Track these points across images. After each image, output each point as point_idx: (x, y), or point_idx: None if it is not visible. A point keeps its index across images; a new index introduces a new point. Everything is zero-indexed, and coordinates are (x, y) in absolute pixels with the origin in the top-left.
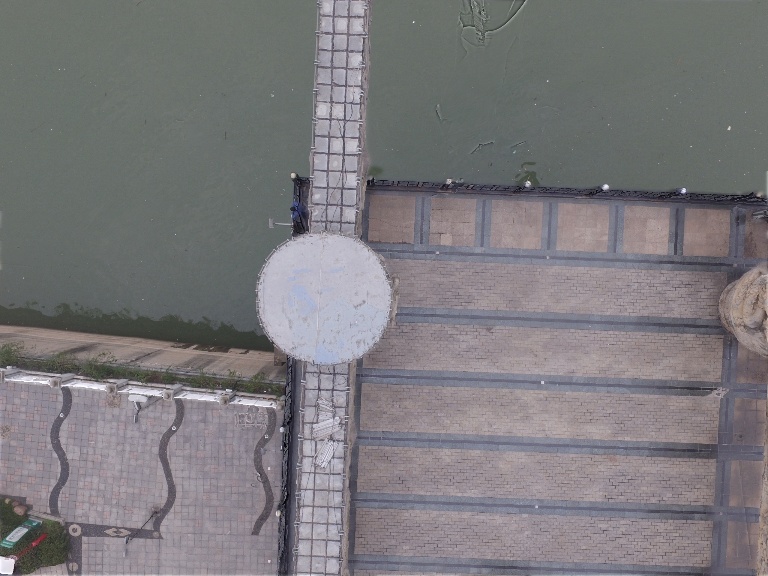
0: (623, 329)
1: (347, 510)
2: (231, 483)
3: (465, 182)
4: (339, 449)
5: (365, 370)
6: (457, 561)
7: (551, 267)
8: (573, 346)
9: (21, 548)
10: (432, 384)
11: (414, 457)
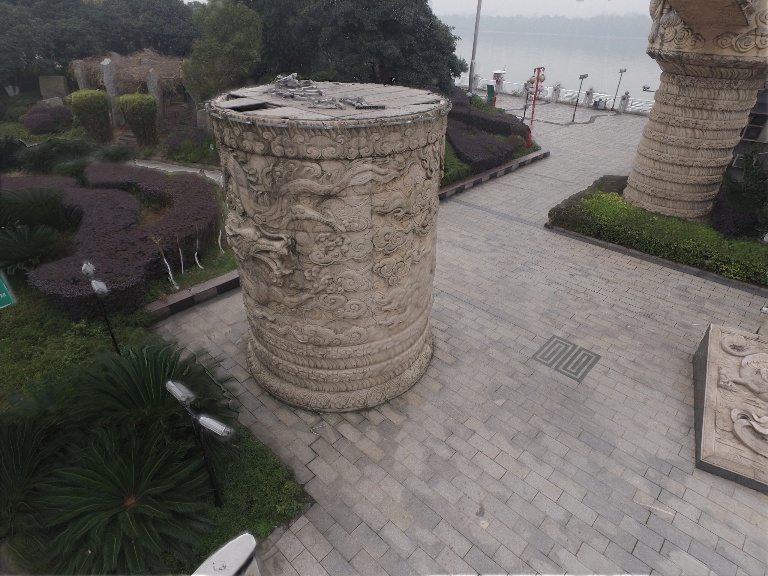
0: None
1: None
2: (640, 128)
3: None
4: None
5: None
6: None
7: None
8: None
9: (482, 100)
10: None
11: None
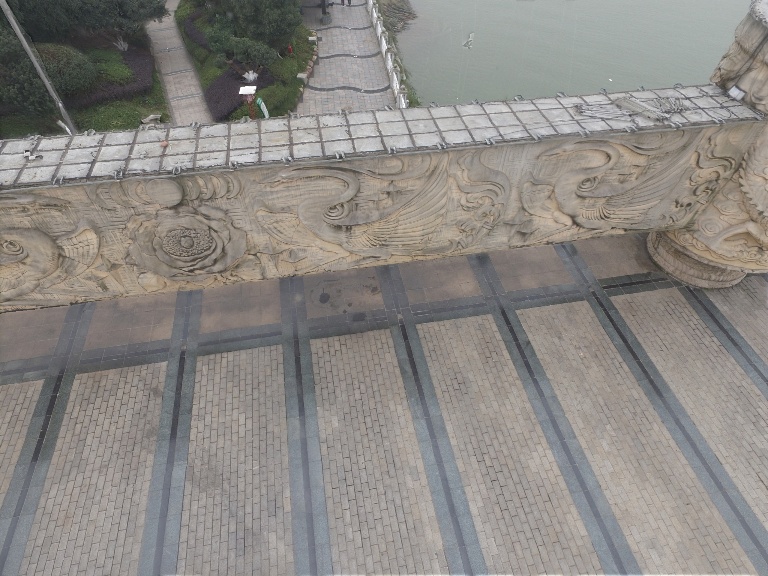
0: None
1: (461, 226)
2: None
3: None
4: (622, 123)
5: (608, 301)
6: (322, 541)
7: None
8: None
9: None
10: (653, 402)
11: (510, 399)
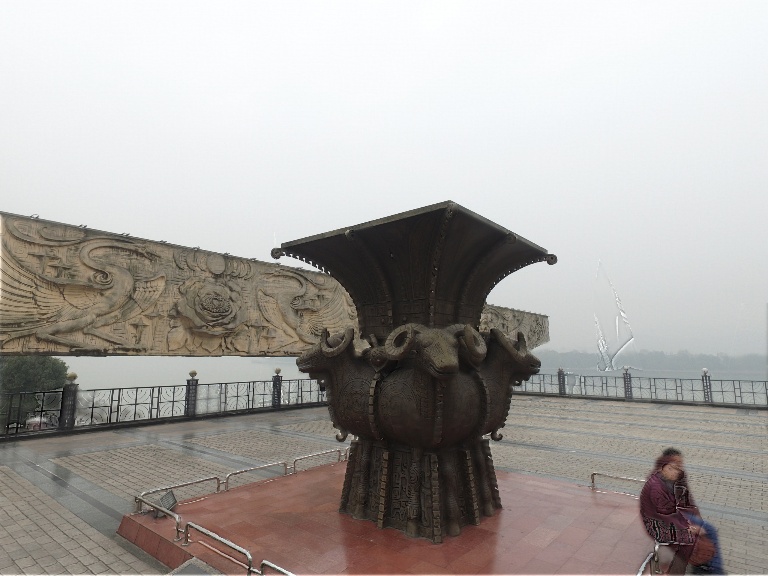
0: (766, 426)
1: None
2: None
3: (575, 374)
4: None
5: None
6: None
7: (659, 410)
8: (681, 422)
9: None
10: None
11: None
